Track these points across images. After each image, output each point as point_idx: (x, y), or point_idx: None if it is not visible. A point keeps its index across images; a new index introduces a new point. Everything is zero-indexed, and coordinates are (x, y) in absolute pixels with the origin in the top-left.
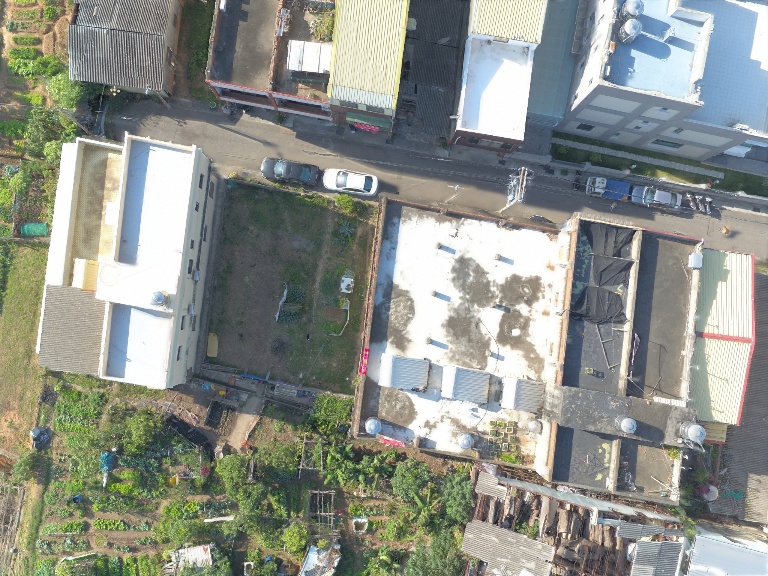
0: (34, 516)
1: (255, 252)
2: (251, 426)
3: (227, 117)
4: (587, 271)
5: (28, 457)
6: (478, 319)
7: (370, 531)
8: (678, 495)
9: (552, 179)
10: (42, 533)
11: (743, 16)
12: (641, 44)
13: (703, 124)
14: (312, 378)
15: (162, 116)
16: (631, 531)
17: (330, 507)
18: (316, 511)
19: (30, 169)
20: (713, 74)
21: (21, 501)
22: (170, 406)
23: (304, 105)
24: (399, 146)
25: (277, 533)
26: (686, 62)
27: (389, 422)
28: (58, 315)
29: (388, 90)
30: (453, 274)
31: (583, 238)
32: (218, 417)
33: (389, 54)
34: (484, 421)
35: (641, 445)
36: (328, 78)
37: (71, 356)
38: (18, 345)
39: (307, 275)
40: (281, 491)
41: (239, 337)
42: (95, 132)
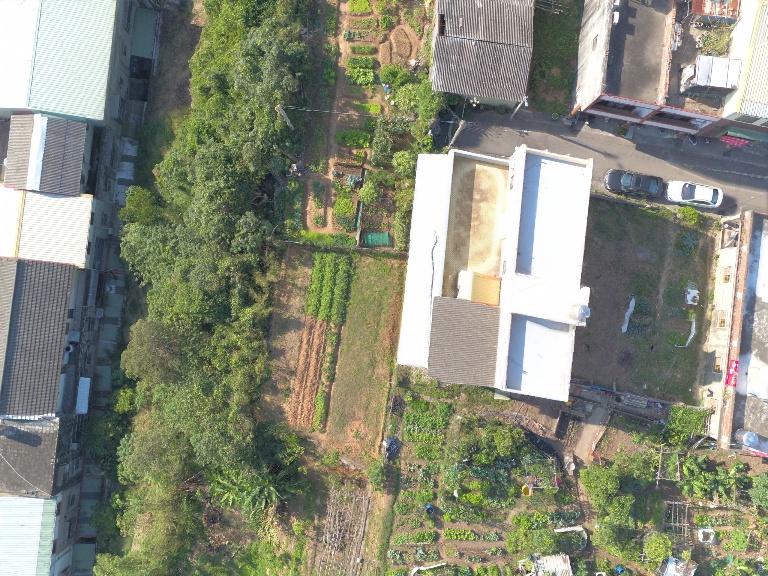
0: (385, 526)
1: (600, 263)
2: (597, 437)
3: (568, 128)
4: None
5: (382, 467)
6: None
7: (715, 541)
8: None
9: None
10: (394, 543)
11: None
12: None
13: None
14: (656, 389)
15: (504, 127)
16: None
17: (684, 518)
18: (670, 522)
19: (376, 179)
20: None
21: (366, 511)
22: (516, 417)
23: (668, 118)
24: (736, 158)
25: (633, 543)
26: None
27: None
28: (448, 327)
29: None
30: None
31: None
32: (564, 428)
33: None
34: None
35: None
36: (725, 93)
37: (463, 368)
38: (362, 355)
39: (652, 287)
40: None
41: (586, 348)
42: (442, 142)
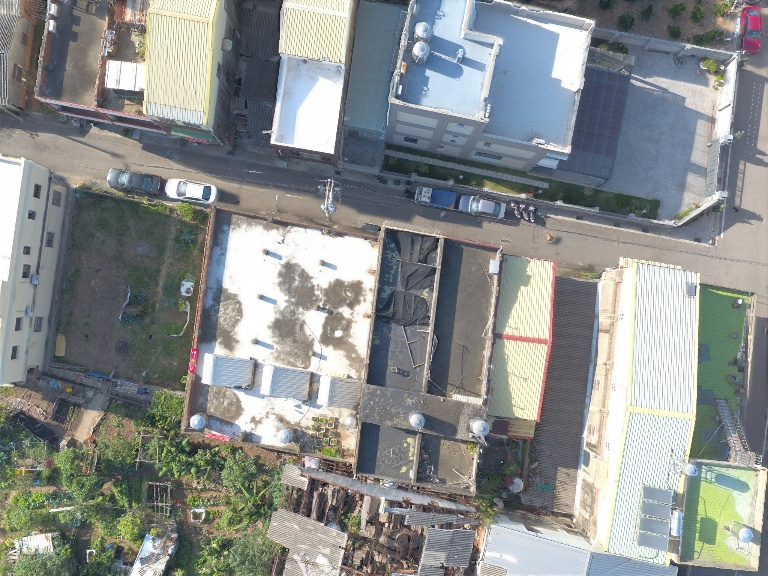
0: None
1: (101, 257)
2: (96, 421)
3: (77, 130)
4: (395, 276)
5: None
6: (302, 321)
7: (208, 521)
8: (474, 486)
9: (385, 189)
10: None
11: (545, 37)
12: (435, 64)
13: (502, 139)
14: (154, 376)
15: (15, 129)
16: (421, 519)
17: (166, 498)
18: (153, 501)
19: None
20: (516, 91)
21: None
22: (20, 402)
23: None
24: (240, 157)
25: (116, 522)
26: (477, 81)
27: (217, 418)
28: None
29: (199, 107)
30: (279, 279)
31: (391, 245)
32: (65, 413)
33: (198, 74)
34: (307, 417)
35: (444, 440)
36: None
37: None
38: None
39: (150, 279)
40: (123, 483)
41: (85, 337)
42: None
